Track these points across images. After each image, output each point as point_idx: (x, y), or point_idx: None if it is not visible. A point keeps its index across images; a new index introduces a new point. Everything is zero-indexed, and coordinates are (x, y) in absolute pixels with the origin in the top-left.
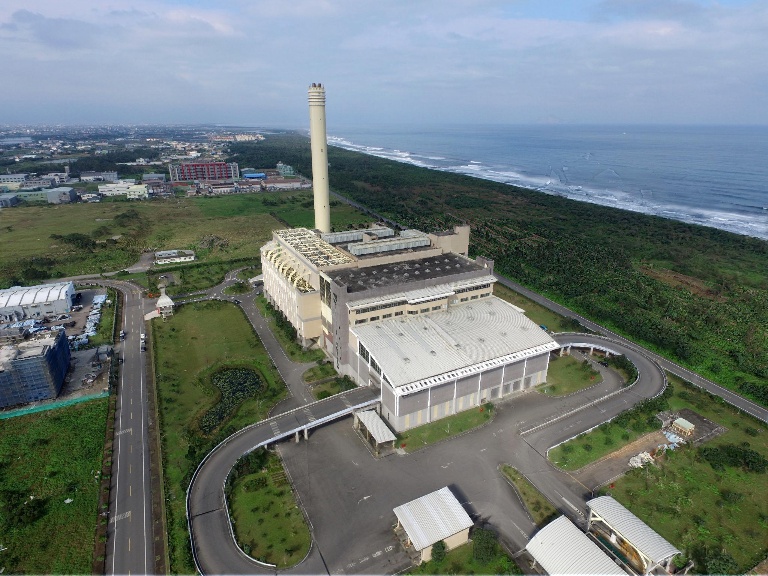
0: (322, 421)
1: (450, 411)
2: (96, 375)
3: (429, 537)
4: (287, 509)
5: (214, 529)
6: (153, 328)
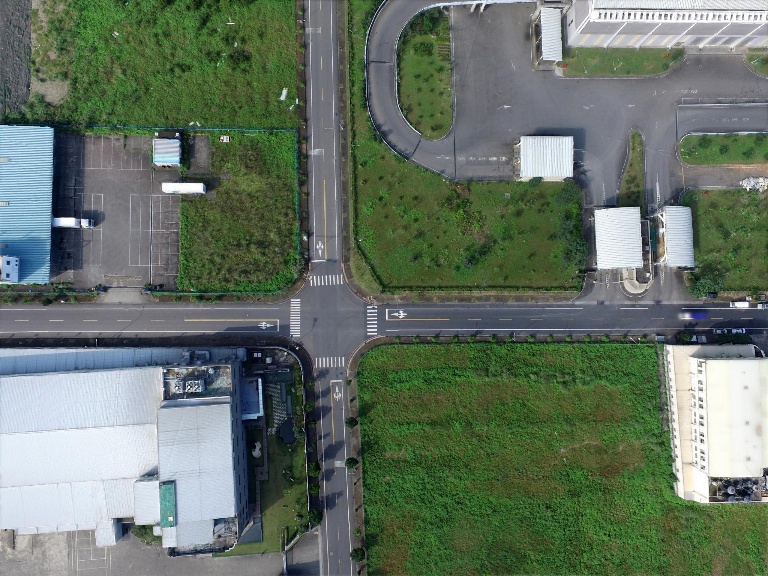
0: (504, 1)
1: (635, 43)
2: None
3: (534, 171)
4: (442, 87)
5: (384, 81)
6: None
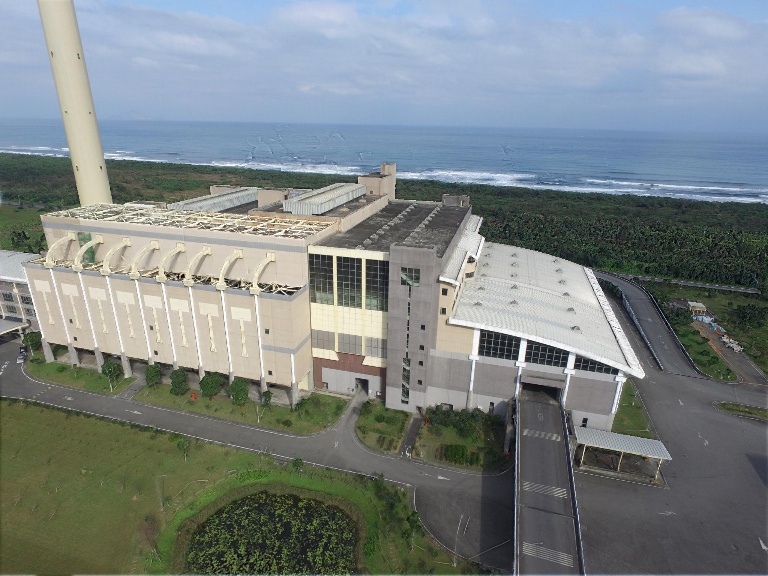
0: None
1: None
2: None
3: None
4: None
5: None
6: None
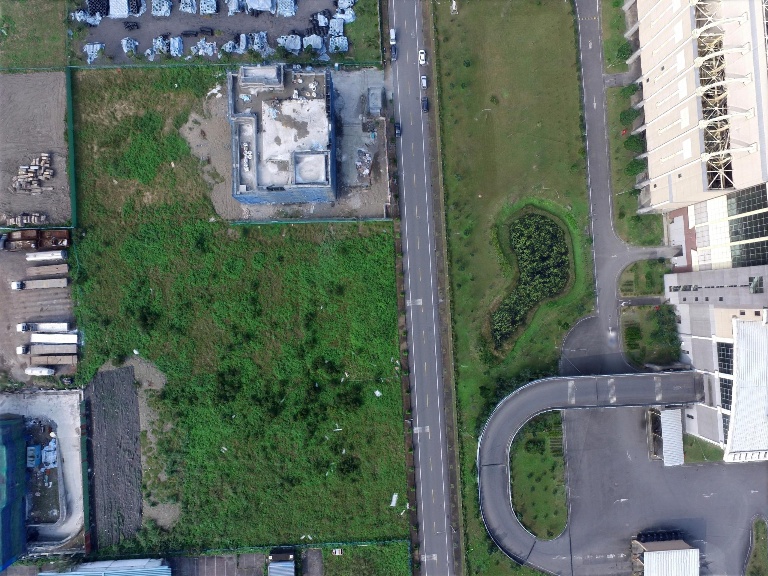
0: None
1: None
2: (371, 158)
3: None
4: (556, 484)
5: (496, 484)
6: (436, 36)
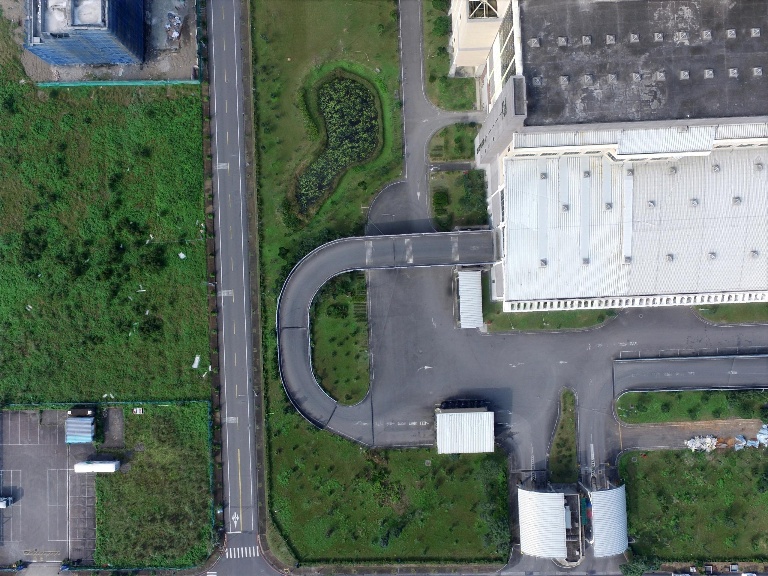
0: None
1: None
2: (181, 21)
3: (452, 448)
4: (358, 350)
5: (297, 347)
6: None
